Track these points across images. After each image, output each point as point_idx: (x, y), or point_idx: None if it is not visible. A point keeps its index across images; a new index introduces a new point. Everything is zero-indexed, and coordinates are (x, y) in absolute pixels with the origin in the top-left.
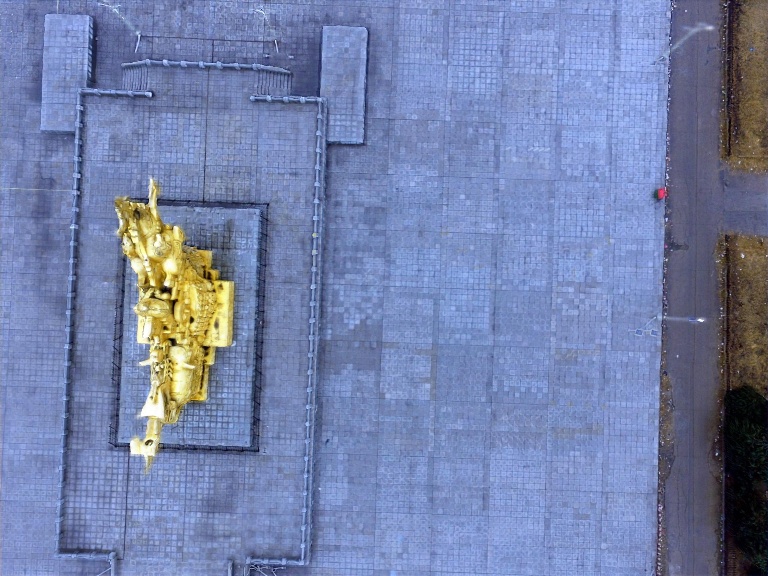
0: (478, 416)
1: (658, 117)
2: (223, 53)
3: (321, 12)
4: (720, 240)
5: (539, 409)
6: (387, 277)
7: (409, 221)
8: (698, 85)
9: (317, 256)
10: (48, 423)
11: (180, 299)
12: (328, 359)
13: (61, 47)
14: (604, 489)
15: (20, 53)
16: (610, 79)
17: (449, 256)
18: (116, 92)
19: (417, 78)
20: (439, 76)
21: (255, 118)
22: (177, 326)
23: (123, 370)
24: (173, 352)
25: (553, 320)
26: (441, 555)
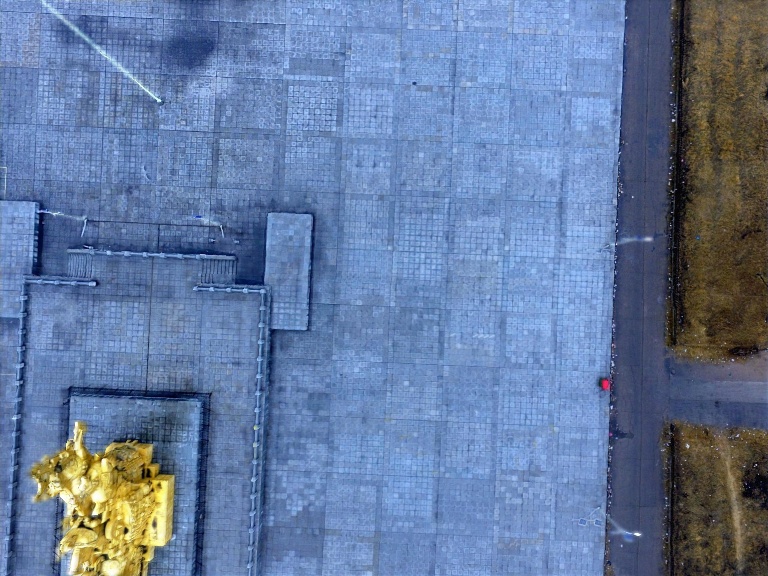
0: None
1: (604, 305)
2: (169, 237)
3: (267, 197)
4: (665, 429)
5: None
6: (330, 463)
7: (353, 407)
8: (644, 272)
9: (259, 447)
10: None
11: (112, 518)
12: (270, 546)
13: (7, 234)
14: None
15: None
16: (556, 266)
17: (392, 443)
18: (60, 283)
19: (362, 264)
20: (384, 262)
21: (199, 307)
22: (110, 542)
23: (63, 563)
24: (106, 567)
25: (496, 508)
26: None
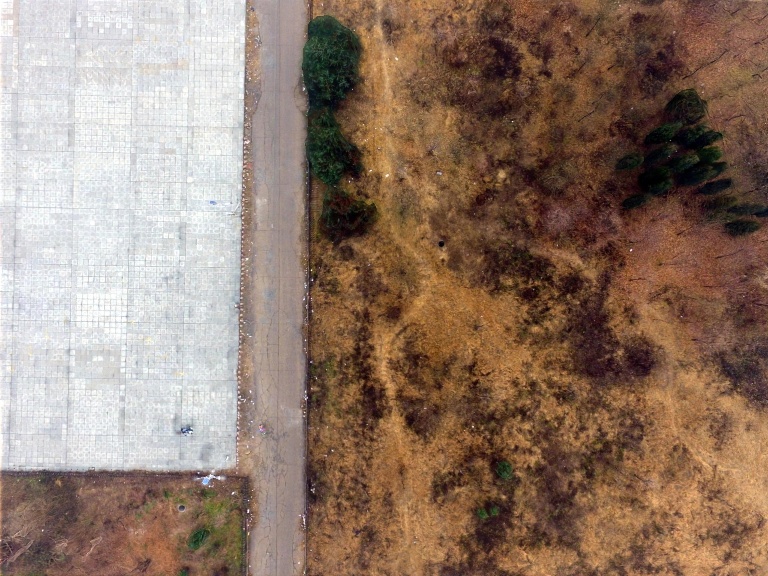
0: (62, 52)
1: None
2: None
3: None
4: None
5: (124, 45)
6: None
7: None
8: None
9: None
10: None
11: None
12: None
13: None
14: (190, 124)
15: None
16: None
17: None
18: None
19: None
20: None
21: None
22: None
23: None
24: None
25: None
26: (26, 190)
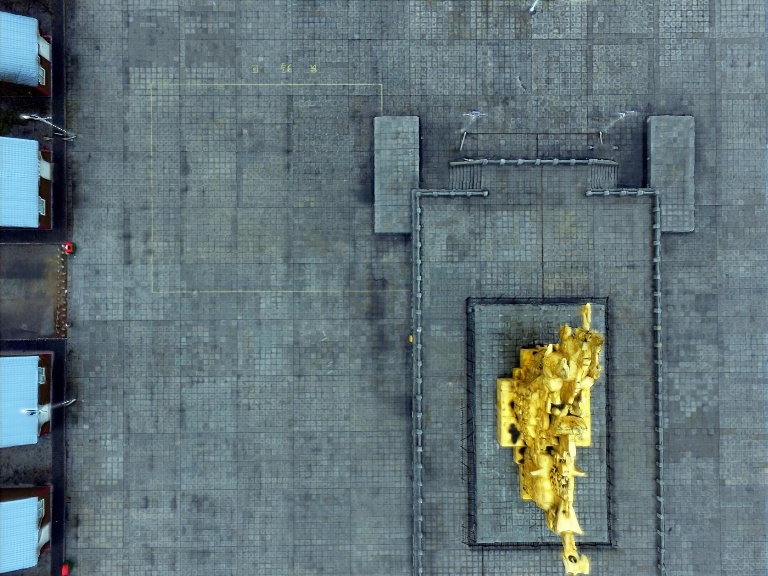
0: None
1: None
2: (547, 147)
3: (643, 101)
4: None
5: None
6: (721, 363)
7: (740, 307)
8: None
9: None
10: (393, 523)
11: None
12: (666, 448)
13: (392, 149)
14: None
15: (347, 156)
16: None
17: None
18: (455, 193)
19: (742, 163)
20: (764, 160)
21: (590, 212)
22: None
23: (478, 471)
24: (567, 461)
25: None
26: None
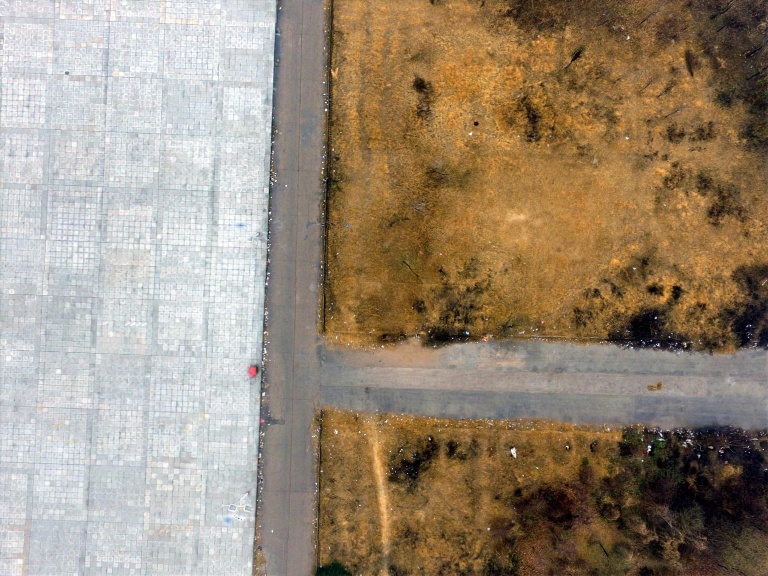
0: None
1: (255, 292)
2: None
3: None
4: (316, 415)
5: None
6: None
7: (4, 396)
8: (297, 260)
9: None
10: None
11: None
12: None
13: None
14: None
15: None
16: (207, 254)
17: (44, 431)
18: None
19: (15, 253)
20: (37, 251)
21: None
22: None
23: None
24: None
25: (147, 495)
26: None
